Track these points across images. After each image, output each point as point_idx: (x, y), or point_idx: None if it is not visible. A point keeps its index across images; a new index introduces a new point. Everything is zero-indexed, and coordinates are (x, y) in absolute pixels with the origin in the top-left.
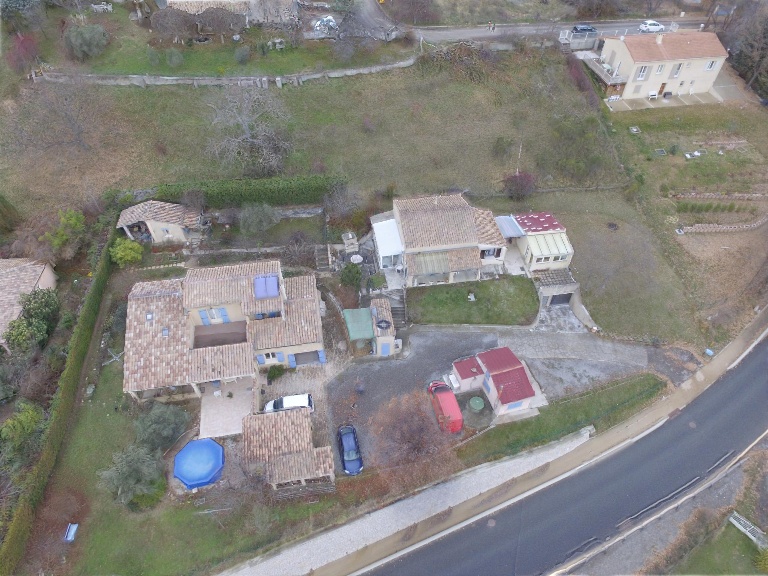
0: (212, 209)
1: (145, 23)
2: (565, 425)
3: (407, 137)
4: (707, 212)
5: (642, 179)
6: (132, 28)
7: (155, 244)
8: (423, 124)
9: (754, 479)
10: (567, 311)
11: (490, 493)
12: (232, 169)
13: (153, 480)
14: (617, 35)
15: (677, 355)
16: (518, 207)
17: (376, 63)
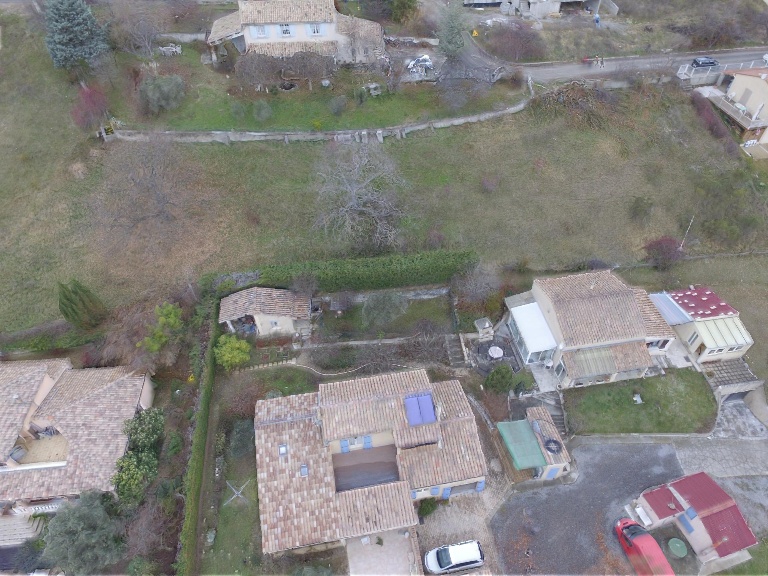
0: (322, 292)
1: (221, 68)
2: None
3: (530, 197)
4: None
5: None
6: (207, 74)
7: (260, 337)
8: (546, 181)
9: None
10: (743, 409)
11: None
12: None
13: None
14: (742, 68)
15: None
16: (664, 278)
17: (485, 110)
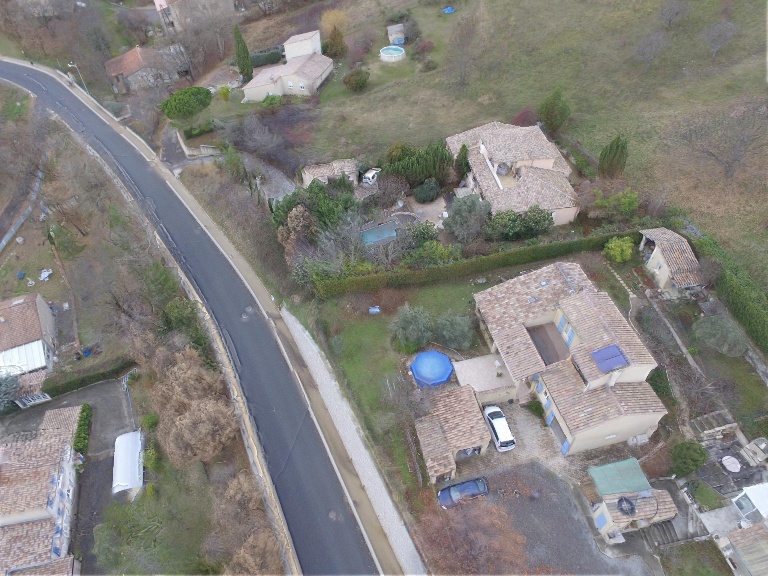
0: (715, 292)
1: None
2: None
3: None
4: None
5: None
6: None
7: (644, 267)
8: None
9: None
10: None
11: None
12: None
13: (409, 339)
14: None
15: None
16: None
17: None
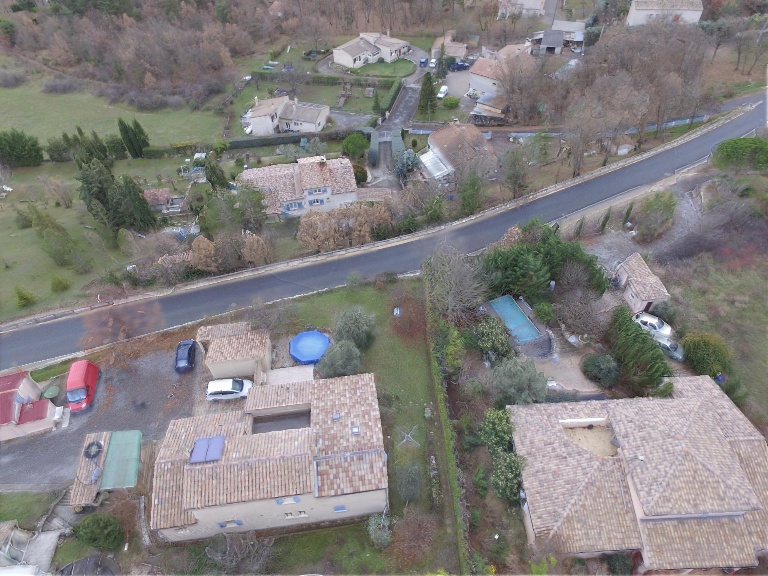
0: None
1: None
2: None
3: None
4: None
5: None
6: None
7: None
8: None
9: None
10: None
11: None
12: None
13: None
14: None
15: None
16: None
17: None
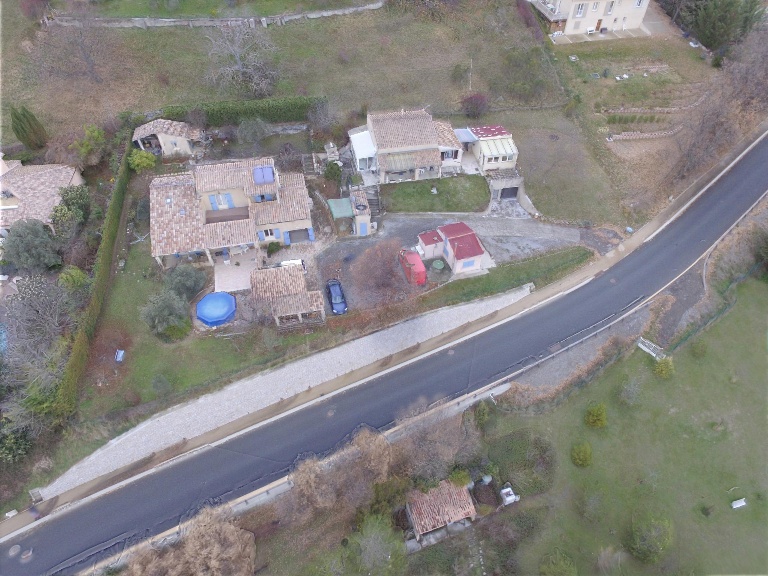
0: (212, 127)
1: None
2: (510, 282)
3: (378, 67)
4: (632, 123)
5: (579, 98)
6: None
7: (165, 157)
8: (391, 56)
9: (658, 316)
10: (515, 203)
11: (450, 333)
12: (227, 95)
13: (182, 316)
14: None
15: (604, 234)
16: (474, 124)
17: (349, 5)
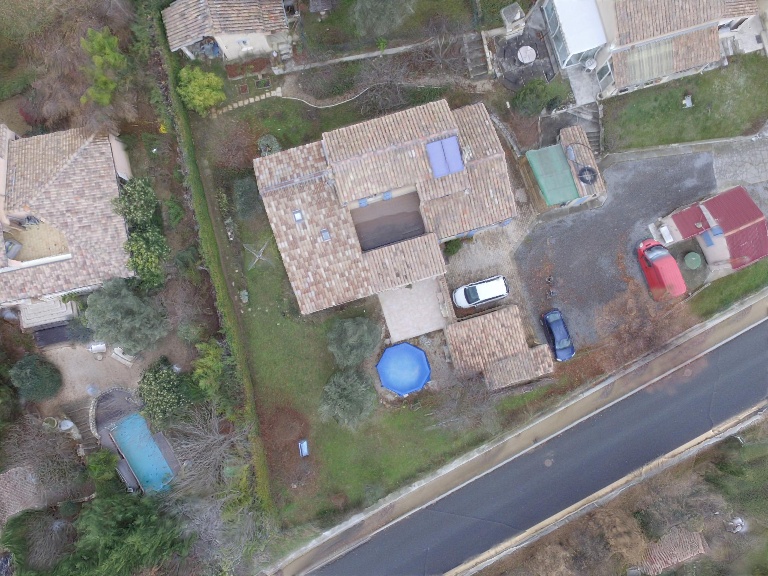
0: None
1: None
2: None
3: None
4: None
5: None
6: None
7: (228, 62)
8: None
9: None
10: None
11: (687, 344)
12: None
13: None
14: None
15: None
16: None
17: None
